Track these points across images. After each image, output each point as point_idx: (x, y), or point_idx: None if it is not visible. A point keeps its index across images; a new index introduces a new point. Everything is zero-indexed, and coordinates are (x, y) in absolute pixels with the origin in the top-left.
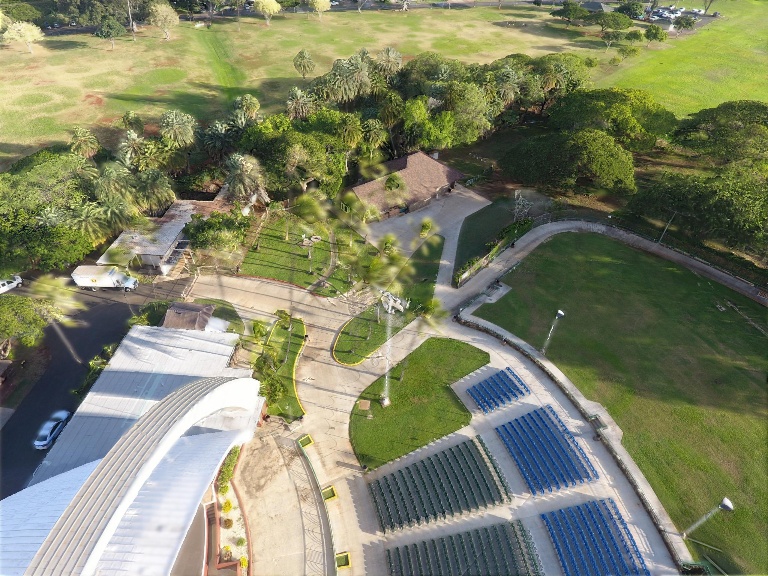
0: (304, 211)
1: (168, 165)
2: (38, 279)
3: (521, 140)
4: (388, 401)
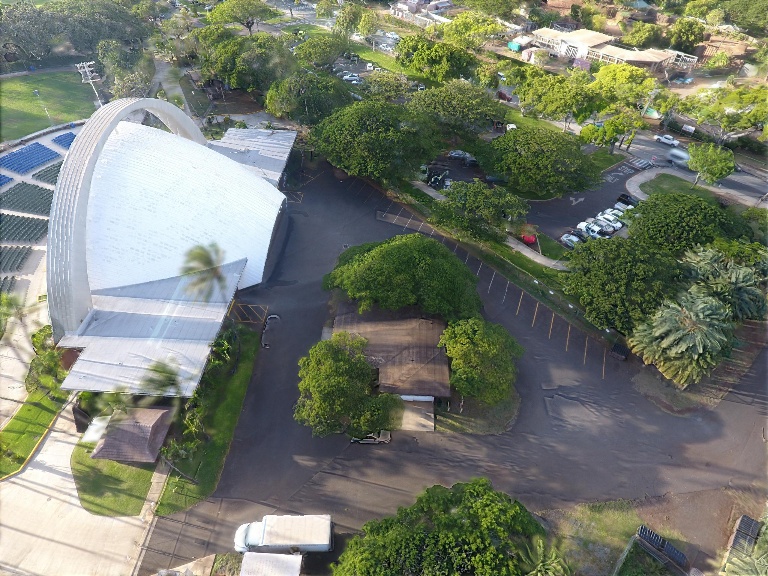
0: None
1: None
2: None
3: None
4: None
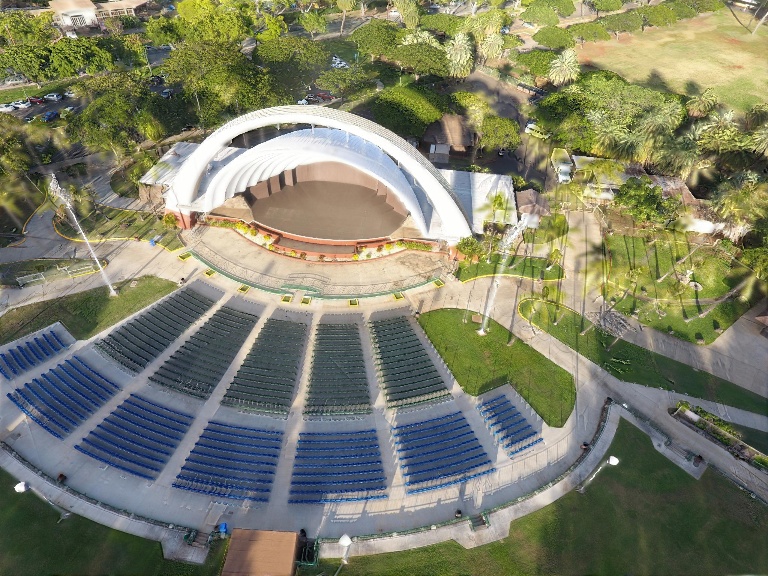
0: (745, 276)
1: (721, 156)
2: (553, 145)
3: None
4: (483, 334)
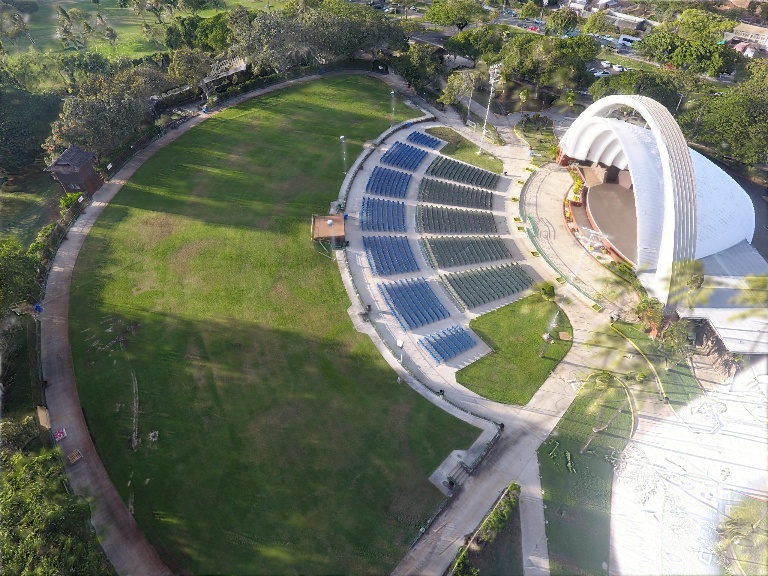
0: None
1: None
2: None
3: None
4: (545, 338)
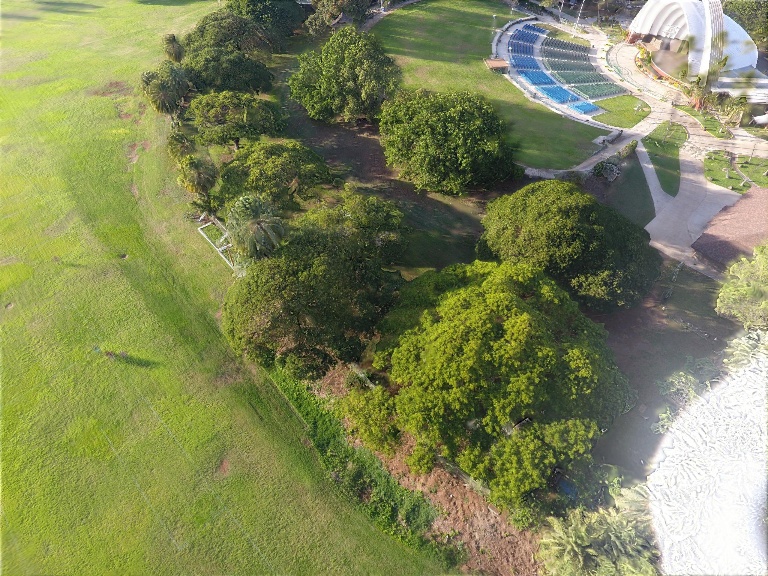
0: None
1: None
2: None
3: (644, 398)
4: (635, 109)
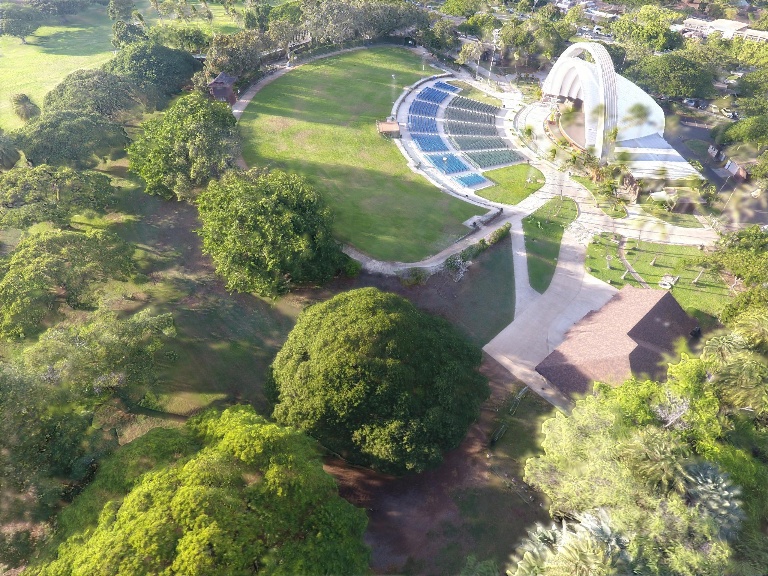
0: (717, 326)
1: None
2: None
3: None
4: (528, 181)
